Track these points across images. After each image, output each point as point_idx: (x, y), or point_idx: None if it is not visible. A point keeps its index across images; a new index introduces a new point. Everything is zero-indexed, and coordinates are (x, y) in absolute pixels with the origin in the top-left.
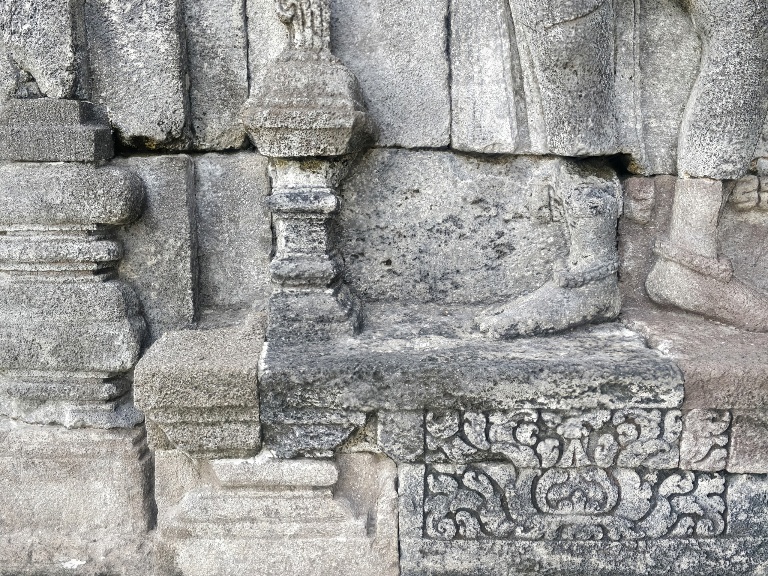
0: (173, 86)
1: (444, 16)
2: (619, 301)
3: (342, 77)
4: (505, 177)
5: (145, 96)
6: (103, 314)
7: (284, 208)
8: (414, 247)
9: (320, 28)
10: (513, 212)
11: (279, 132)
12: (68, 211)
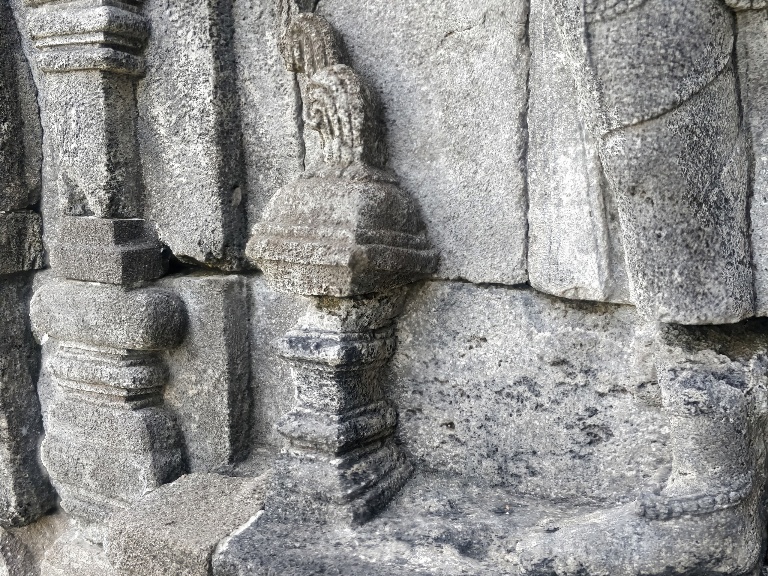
0: (212, 203)
1: (519, 113)
2: (750, 549)
3: (354, 200)
4: (602, 332)
5: (188, 213)
6: (130, 444)
7: (285, 355)
8: (479, 412)
9: (350, 137)
10: (610, 383)
11: (280, 265)
12: (102, 334)
